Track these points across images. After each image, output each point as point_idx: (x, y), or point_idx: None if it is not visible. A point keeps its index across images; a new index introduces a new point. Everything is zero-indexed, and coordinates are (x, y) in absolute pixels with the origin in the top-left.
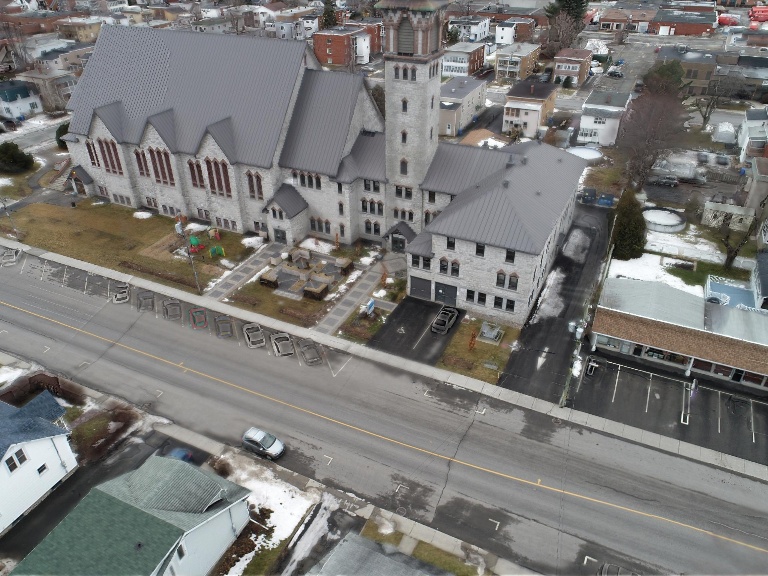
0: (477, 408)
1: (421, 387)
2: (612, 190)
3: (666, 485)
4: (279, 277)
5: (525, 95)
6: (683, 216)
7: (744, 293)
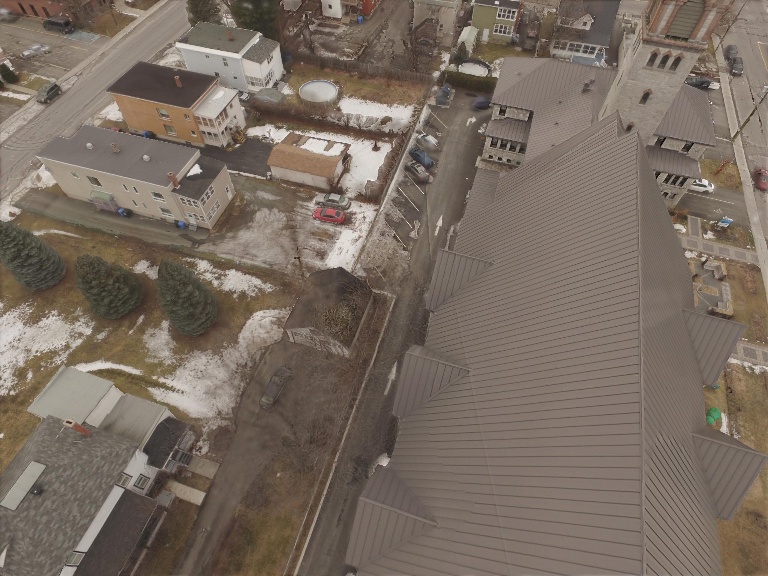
0: (764, 173)
1: (767, 198)
2: (403, 90)
3: (761, 115)
4: (707, 308)
5: (188, 93)
6: (470, 60)
7: (577, 59)
